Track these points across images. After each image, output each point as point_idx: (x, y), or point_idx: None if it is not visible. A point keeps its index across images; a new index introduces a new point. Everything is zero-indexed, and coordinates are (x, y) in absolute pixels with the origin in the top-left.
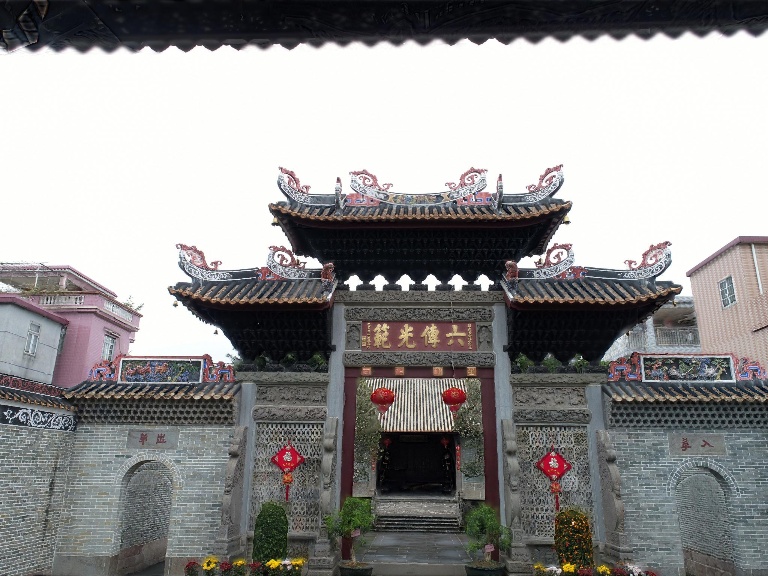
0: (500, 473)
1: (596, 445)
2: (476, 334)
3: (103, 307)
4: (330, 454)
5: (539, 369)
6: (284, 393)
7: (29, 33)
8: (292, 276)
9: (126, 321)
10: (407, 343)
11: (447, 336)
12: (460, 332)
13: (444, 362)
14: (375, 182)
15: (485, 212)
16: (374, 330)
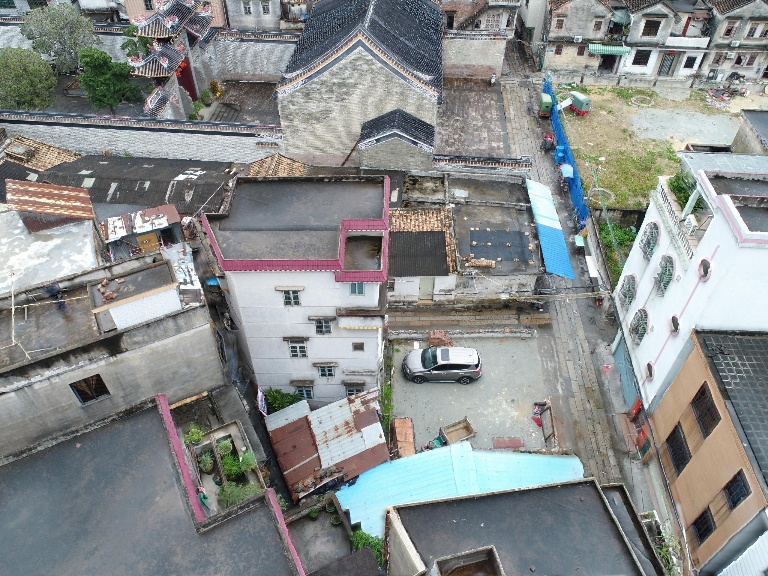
0: (195, 79)
1: (202, 62)
2: None
3: None
4: (188, 96)
5: None
6: (170, 86)
7: None
8: None
9: None
10: None
11: None
12: None
13: None
14: (160, 3)
15: (186, 8)
16: None
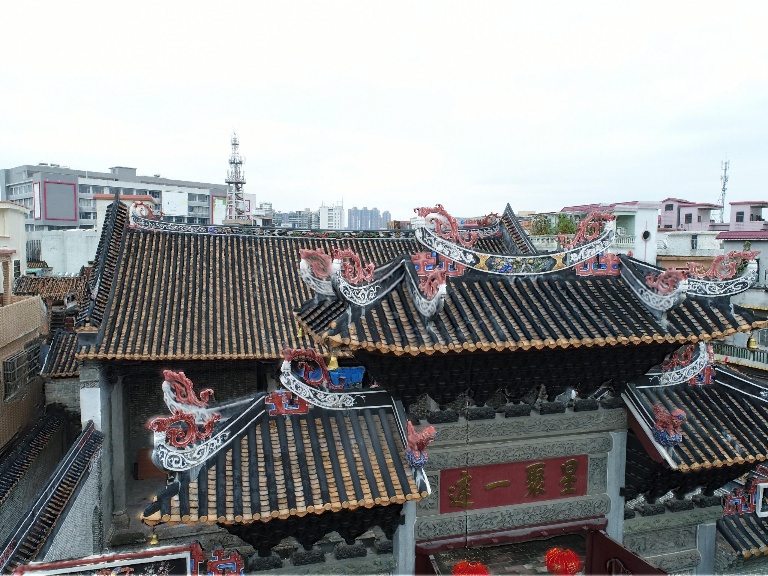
0: None
1: None
2: None
3: None
4: None
5: None
6: None
7: None
8: None
9: None
10: None
11: None
12: None
13: None
14: None
15: None
16: None
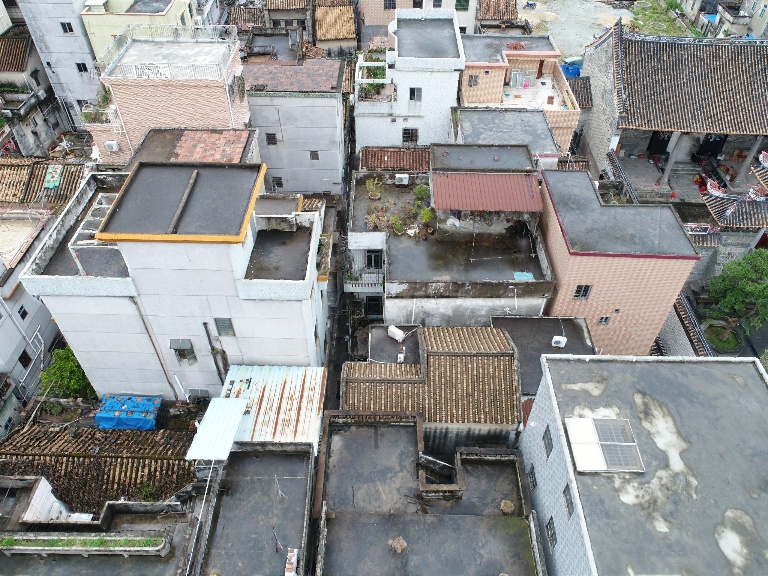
0: None
1: None
2: None
3: None
4: None
5: None
6: None
7: None
8: None
9: None
10: None
11: None
12: None
13: None
14: None
15: None
16: None
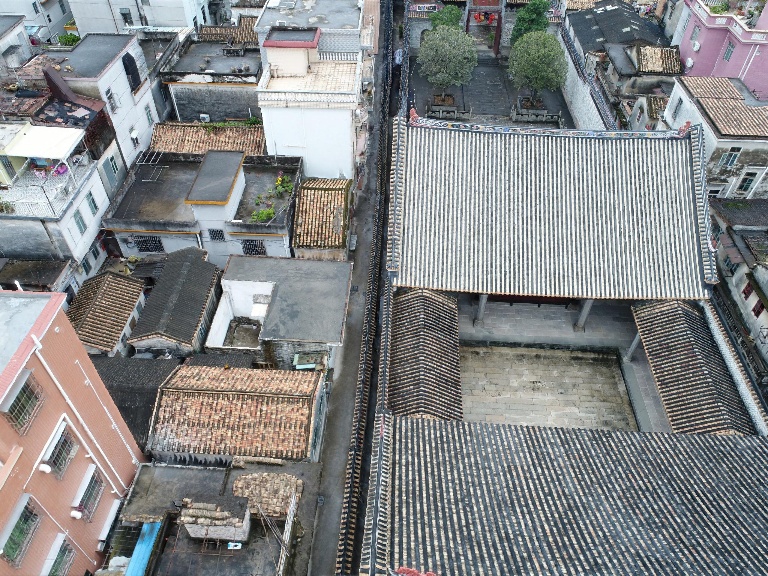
0: None
1: None
2: (473, 1)
3: (694, 6)
4: None
5: (459, 9)
6: None
7: None
8: None
9: (703, 18)
10: (488, 4)
11: (479, 2)
12: (477, 0)
13: (479, 8)
14: None
15: None
16: (496, 1)
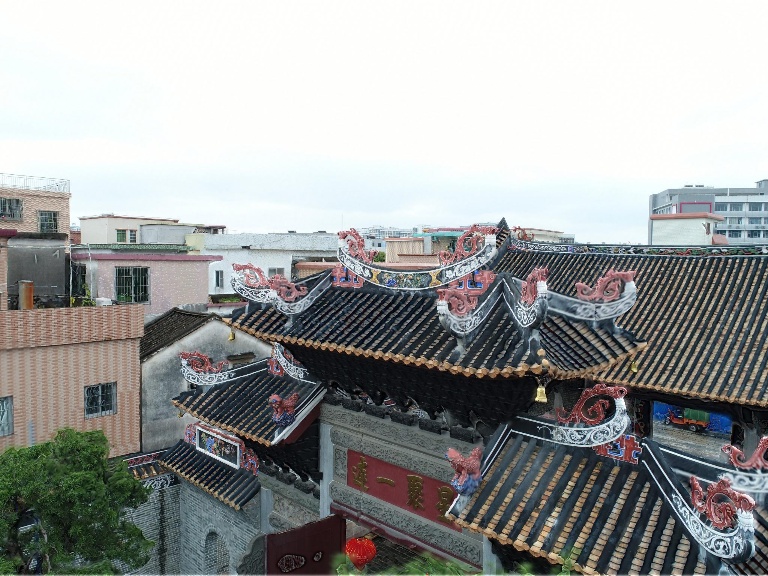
0: None
1: None
2: None
3: None
4: None
5: None
6: None
7: (765, 400)
8: (578, 440)
9: None
10: None
11: None
12: None
13: None
14: None
15: None
16: None
